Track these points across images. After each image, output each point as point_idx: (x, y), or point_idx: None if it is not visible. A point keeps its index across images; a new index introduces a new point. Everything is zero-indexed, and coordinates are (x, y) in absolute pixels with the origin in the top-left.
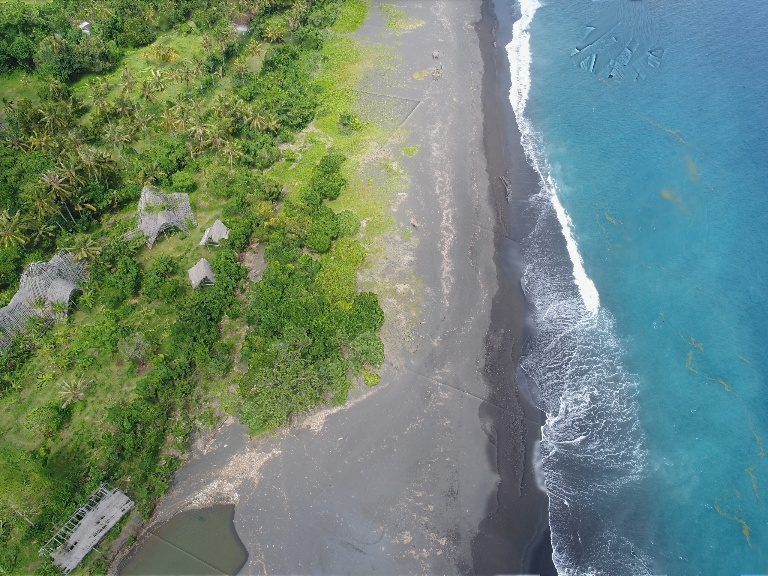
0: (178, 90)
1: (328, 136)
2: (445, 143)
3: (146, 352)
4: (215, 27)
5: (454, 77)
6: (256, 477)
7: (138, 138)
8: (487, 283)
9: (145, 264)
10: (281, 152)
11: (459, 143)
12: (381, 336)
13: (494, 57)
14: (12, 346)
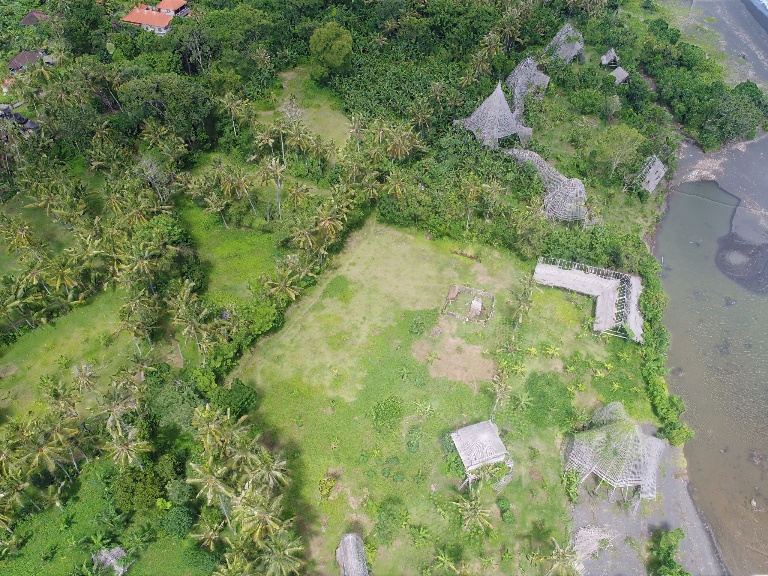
0: None
1: (637, 15)
2: (730, 17)
3: None
4: None
5: None
6: (720, 169)
7: None
8: None
9: None
10: None
11: (739, 18)
12: None
13: None
14: (525, 107)
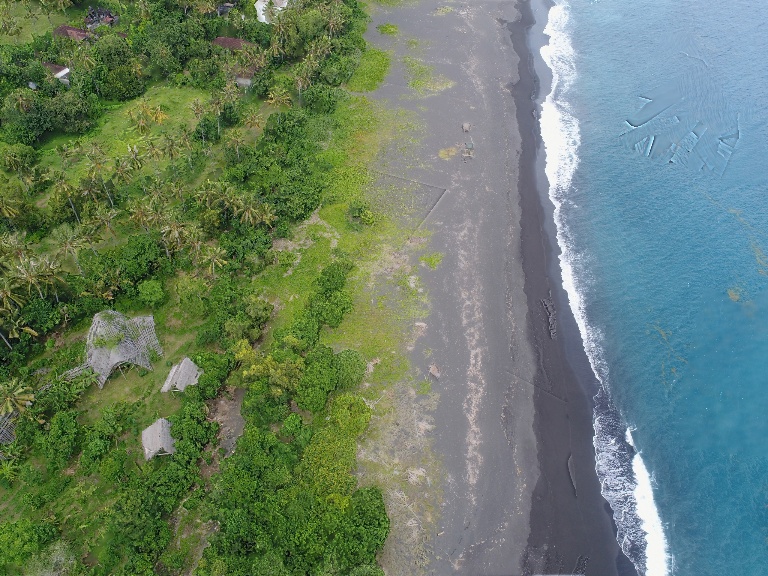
0: (163, 159)
1: (334, 231)
2: (475, 250)
3: (68, 571)
4: (214, 80)
5: (487, 157)
6: None
7: (99, 238)
8: (525, 466)
9: (91, 412)
10: (275, 255)
11: (492, 250)
12: (384, 556)
13: (533, 131)
14: None
